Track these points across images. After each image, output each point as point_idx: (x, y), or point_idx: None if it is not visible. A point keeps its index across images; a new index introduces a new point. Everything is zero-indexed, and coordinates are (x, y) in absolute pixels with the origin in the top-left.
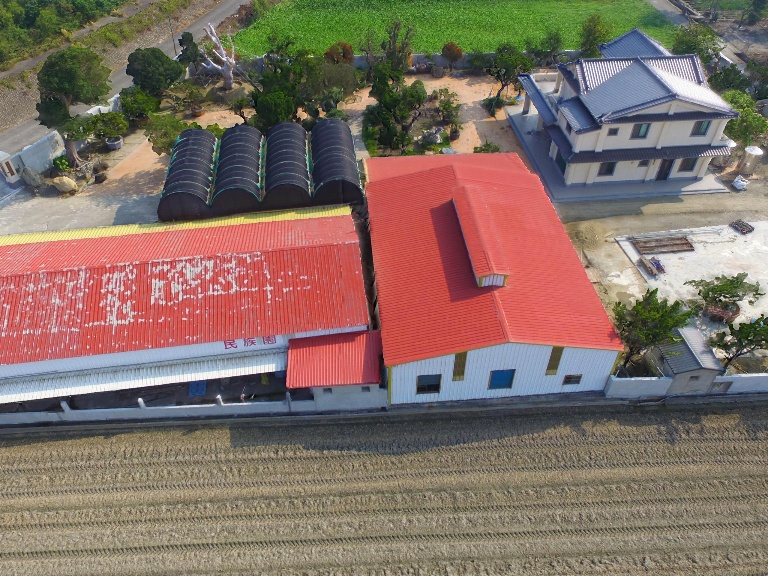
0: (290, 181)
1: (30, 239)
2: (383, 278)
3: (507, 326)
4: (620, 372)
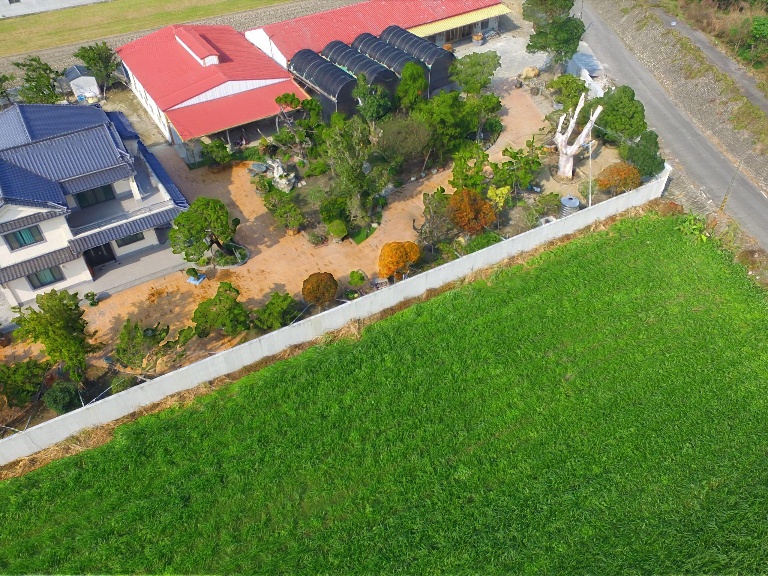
0: (333, 43)
1: (457, 22)
2: None
3: None
4: (117, 87)
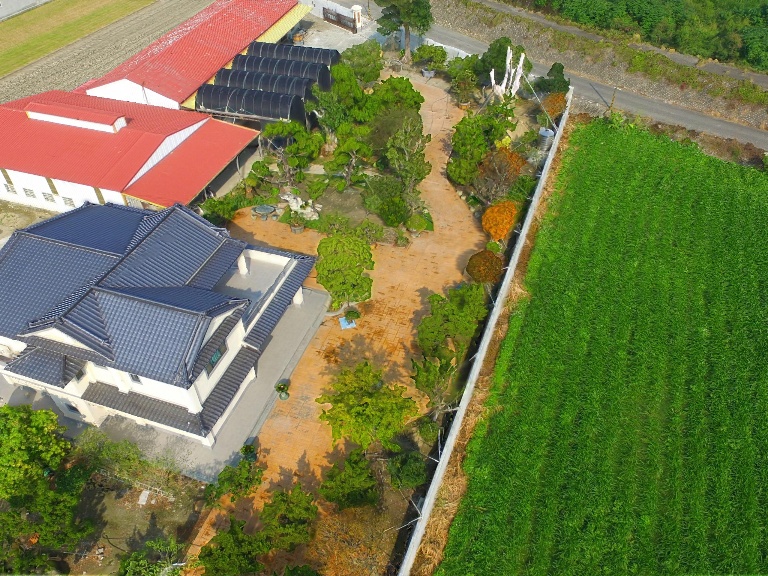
0: (221, 71)
1: (283, 28)
2: (108, 99)
3: (5, 108)
4: None
